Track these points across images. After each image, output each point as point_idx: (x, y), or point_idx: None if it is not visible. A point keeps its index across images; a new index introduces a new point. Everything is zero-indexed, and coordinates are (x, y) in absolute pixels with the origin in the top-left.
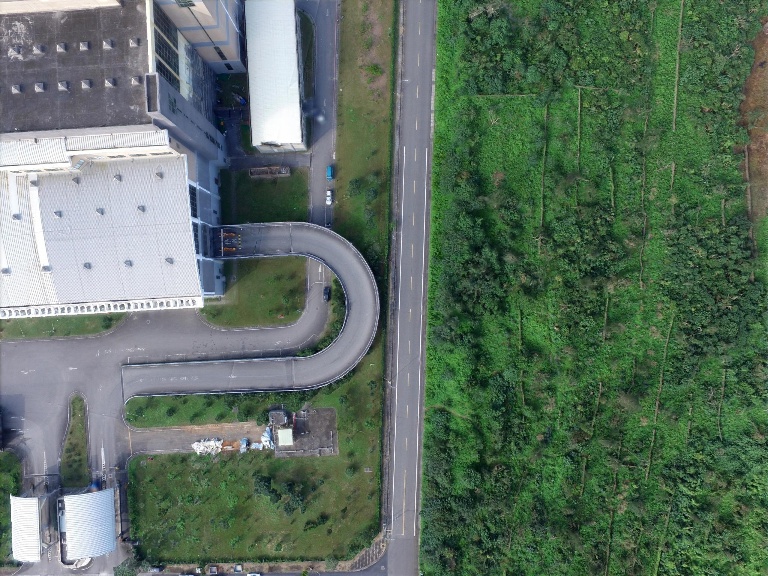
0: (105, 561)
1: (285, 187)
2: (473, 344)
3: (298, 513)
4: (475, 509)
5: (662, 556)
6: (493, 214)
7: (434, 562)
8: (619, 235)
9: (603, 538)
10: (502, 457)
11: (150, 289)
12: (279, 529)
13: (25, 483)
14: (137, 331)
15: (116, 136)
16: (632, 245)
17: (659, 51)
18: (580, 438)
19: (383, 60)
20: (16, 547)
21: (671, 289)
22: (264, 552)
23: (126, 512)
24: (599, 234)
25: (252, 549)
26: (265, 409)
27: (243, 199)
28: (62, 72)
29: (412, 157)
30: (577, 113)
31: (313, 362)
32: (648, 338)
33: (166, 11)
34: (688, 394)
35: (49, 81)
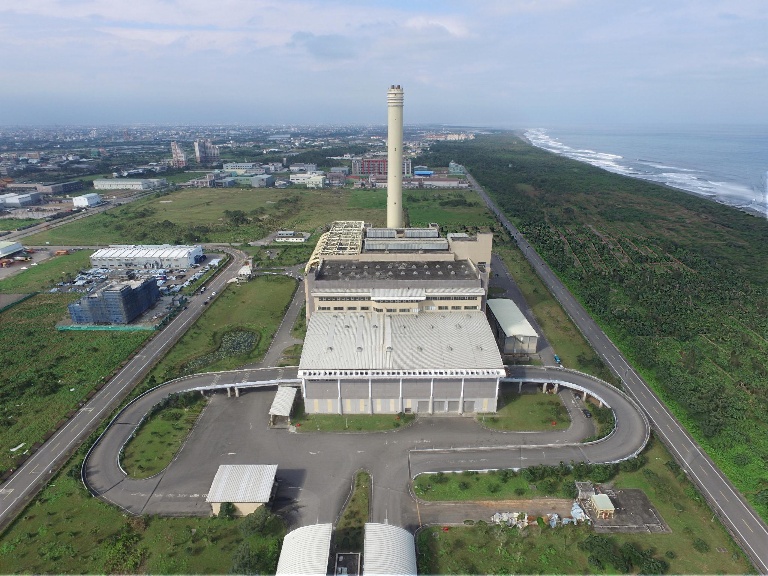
0: None
1: None
2: None
3: None
4: None
5: None
6: None
7: None
8: None
9: None
10: None
11: (464, 363)
12: None
13: None
14: (423, 430)
15: None
16: None
17: None
18: None
19: None
20: None
21: None
22: None
23: None
24: None
25: None
26: None
27: None
28: None
29: None
30: None
31: (600, 447)
32: None
33: None
34: None
35: None
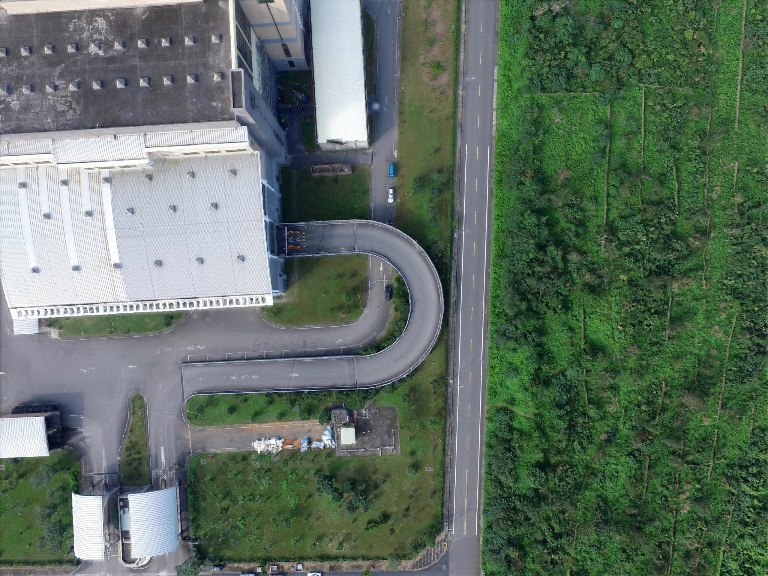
0: (165, 560)
1: (346, 185)
2: (536, 343)
3: (359, 512)
4: (540, 508)
5: (724, 556)
6: (556, 212)
7: (499, 561)
8: (682, 234)
9: (666, 538)
10: (565, 456)
11: (220, 287)
12: (340, 528)
13: (84, 481)
14: (197, 329)
15: (196, 133)
16: (697, 244)
17: (722, 49)
18: (644, 437)
19: (445, 58)
20: (79, 546)
21: (734, 288)
22: (325, 551)
23: (186, 511)
24: (663, 233)
25: (314, 548)
26: (326, 408)
27: (304, 197)
28: (143, 68)
29: (474, 155)
30: (641, 111)
31: (376, 360)
32: (710, 337)
33: (244, 7)
34: (751, 393)
35: (130, 77)
